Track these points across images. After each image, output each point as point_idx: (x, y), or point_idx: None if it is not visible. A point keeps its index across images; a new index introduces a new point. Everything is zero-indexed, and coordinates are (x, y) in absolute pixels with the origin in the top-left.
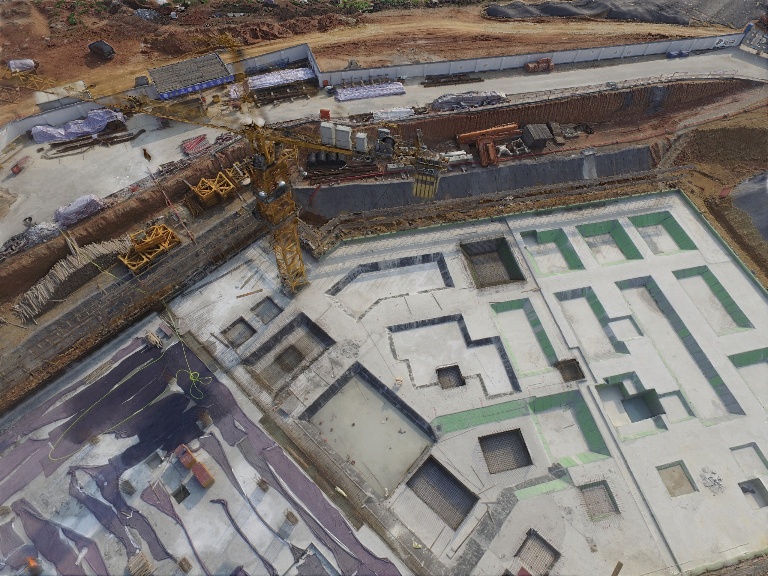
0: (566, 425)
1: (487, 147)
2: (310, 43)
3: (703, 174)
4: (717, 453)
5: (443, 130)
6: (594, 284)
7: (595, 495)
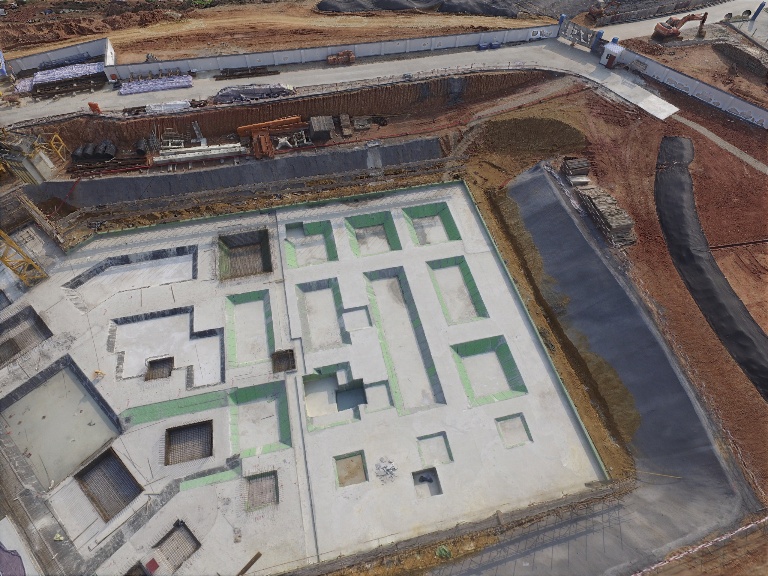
0: (265, 416)
1: (259, 139)
2: (123, 38)
3: (492, 165)
4: (402, 442)
5: (223, 123)
6: (341, 275)
7: (261, 486)
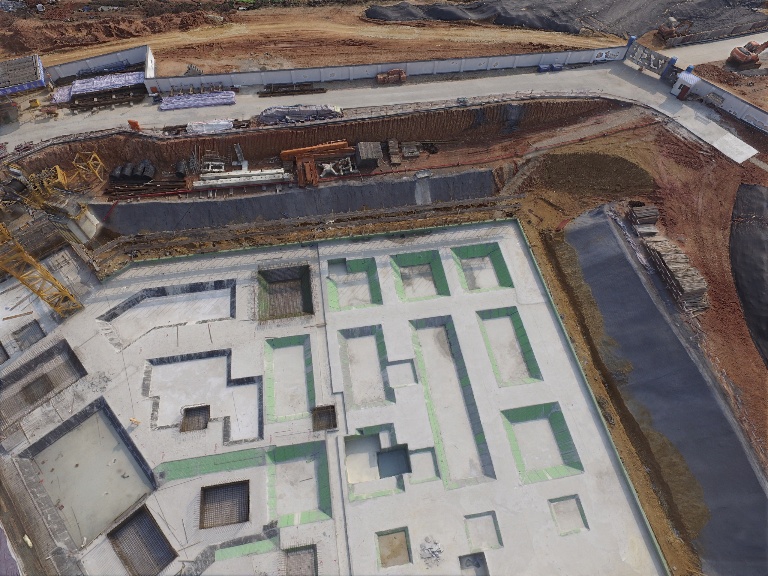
0: (304, 478)
1: (304, 166)
2: (163, 43)
3: (548, 202)
4: (448, 521)
5: (266, 145)
6: (386, 322)
7: (300, 560)
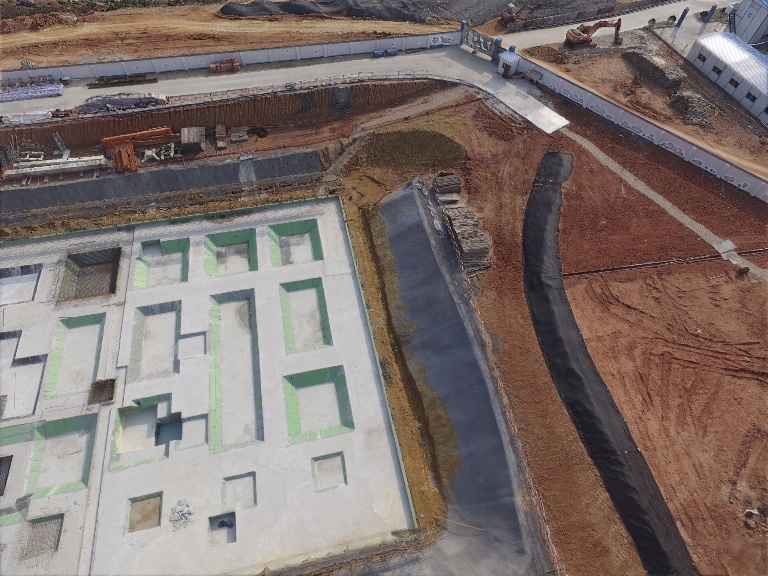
0: (72, 451)
1: (120, 152)
2: (9, 43)
3: (372, 179)
4: (206, 484)
5: (87, 134)
6: (186, 298)
7: (45, 530)
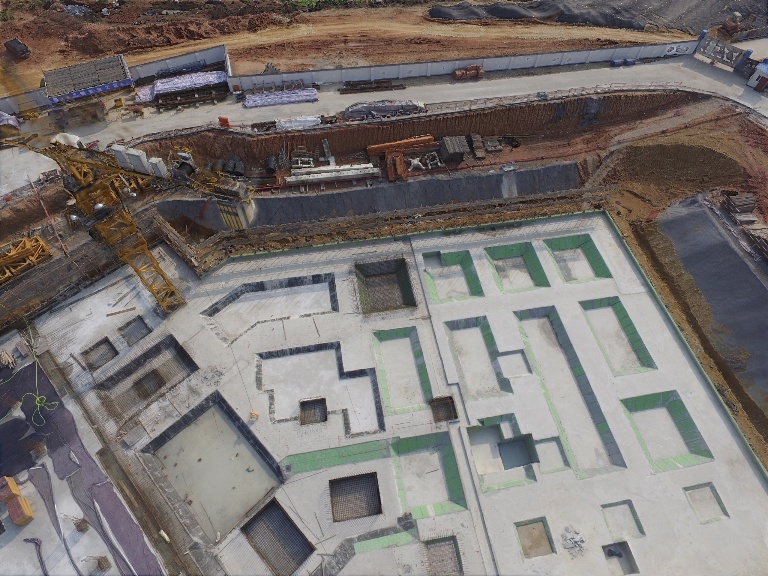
0: (430, 470)
1: (394, 161)
2: (235, 44)
3: (634, 194)
4: (586, 510)
5: (352, 141)
6: (490, 313)
7: (441, 552)
